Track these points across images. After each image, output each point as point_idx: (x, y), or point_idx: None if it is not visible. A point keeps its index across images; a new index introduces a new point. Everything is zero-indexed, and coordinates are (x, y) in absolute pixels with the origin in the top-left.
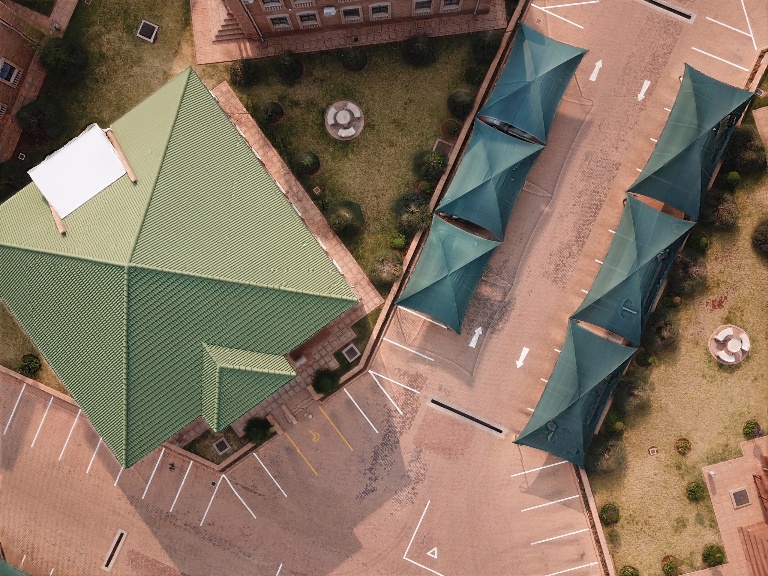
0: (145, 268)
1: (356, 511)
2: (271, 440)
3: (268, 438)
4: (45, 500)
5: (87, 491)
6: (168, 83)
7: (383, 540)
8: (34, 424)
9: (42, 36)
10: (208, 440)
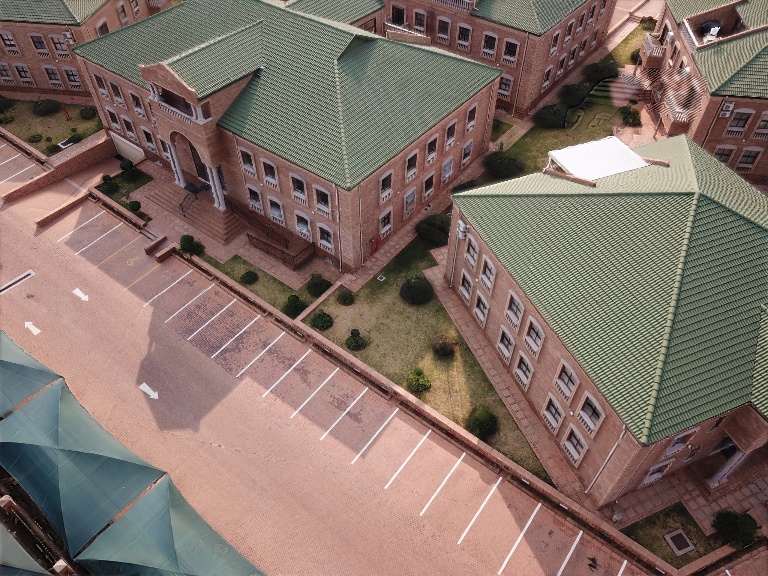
0: (715, 201)
1: None
2: (753, 555)
3: (749, 549)
4: (386, 571)
5: (454, 572)
6: None
7: None
8: (397, 459)
9: (487, 149)
10: (657, 529)
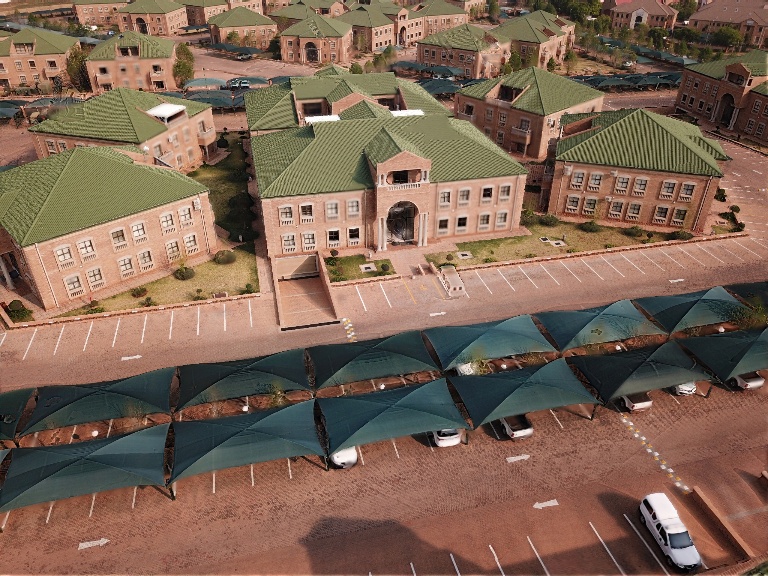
0: None
1: (26, 150)
2: None
3: None
4: None
5: None
6: (148, 138)
7: (10, 149)
8: None
9: None
10: None
